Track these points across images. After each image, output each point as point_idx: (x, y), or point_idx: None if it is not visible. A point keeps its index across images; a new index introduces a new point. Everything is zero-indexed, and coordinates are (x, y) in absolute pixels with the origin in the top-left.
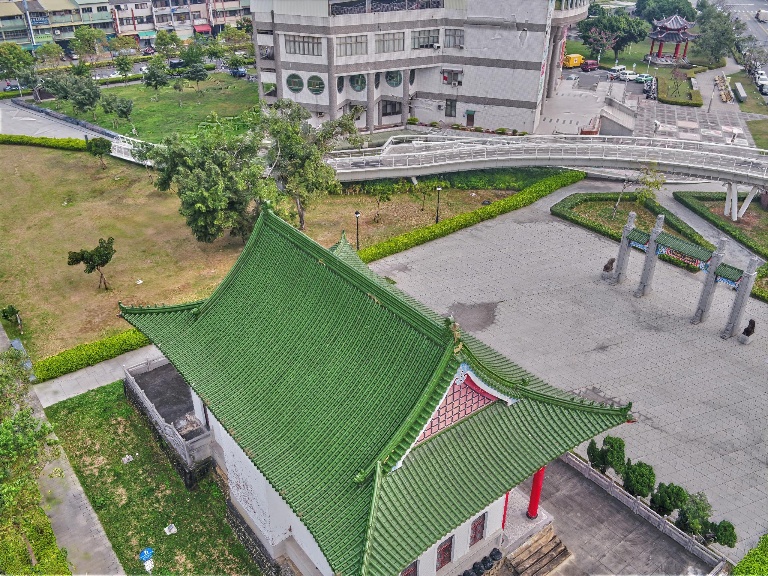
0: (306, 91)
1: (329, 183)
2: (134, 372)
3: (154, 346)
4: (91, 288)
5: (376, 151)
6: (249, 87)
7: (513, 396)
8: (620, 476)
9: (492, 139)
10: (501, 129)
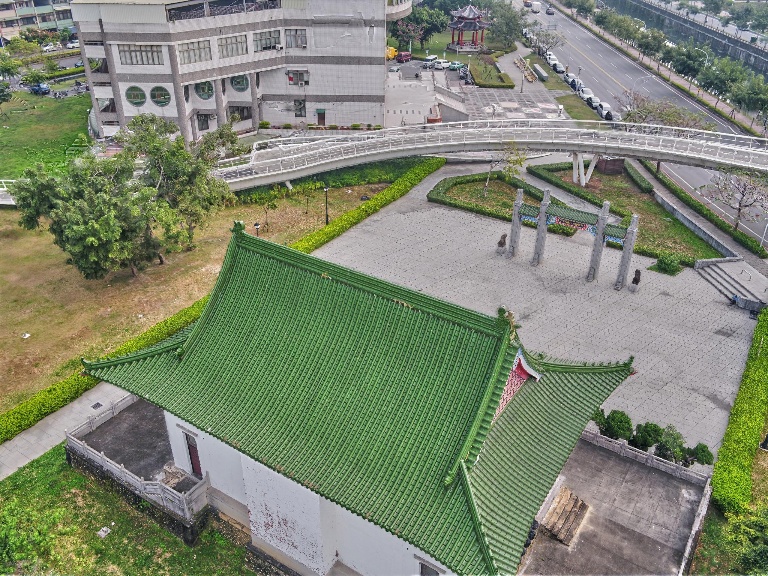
0: (150, 104)
1: (226, 197)
2: (77, 435)
3: (77, 403)
4: None
5: (245, 159)
6: (60, 105)
7: (540, 372)
8: (602, 426)
9: (354, 135)
10: (355, 125)
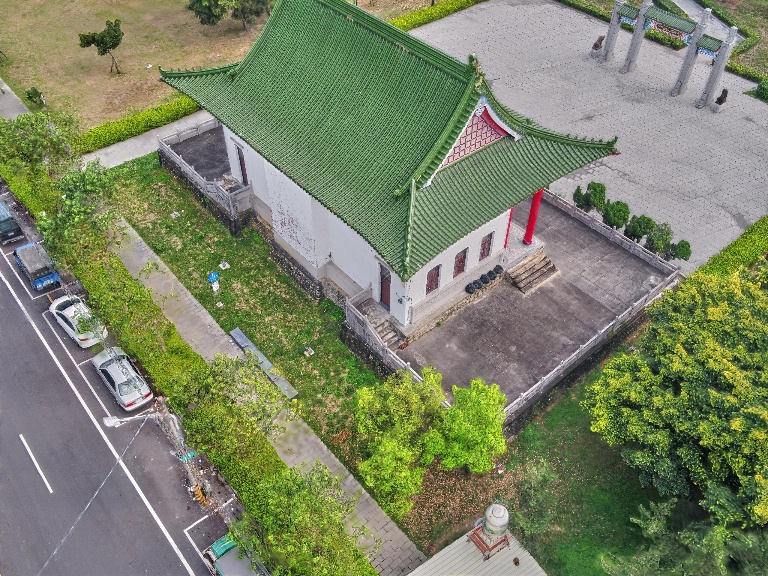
0: None
1: None
2: (167, 142)
3: (177, 123)
4: (103, 72)
5: None
6: None
7: (519, 132)
8: (600, 212)
9: None
10: None
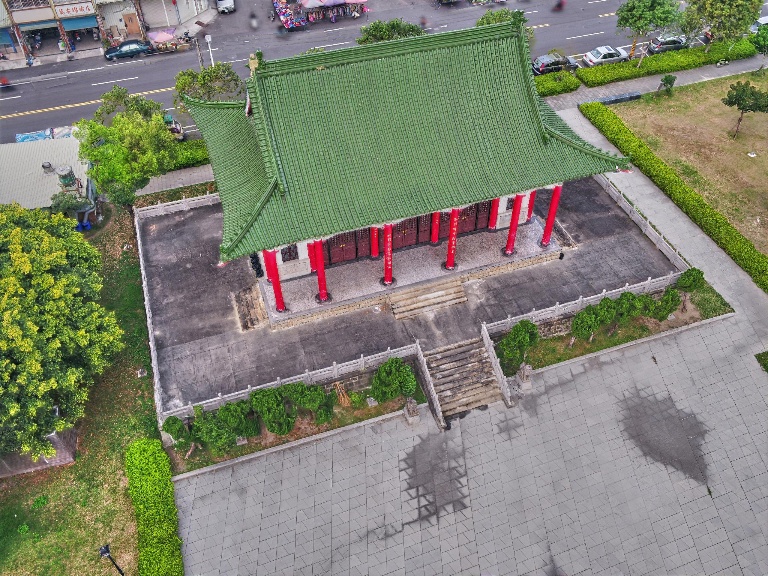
0: None
1: None
2: None
3: None
4: None
5: None
6: None
7: None
8: None
9: None
10: None
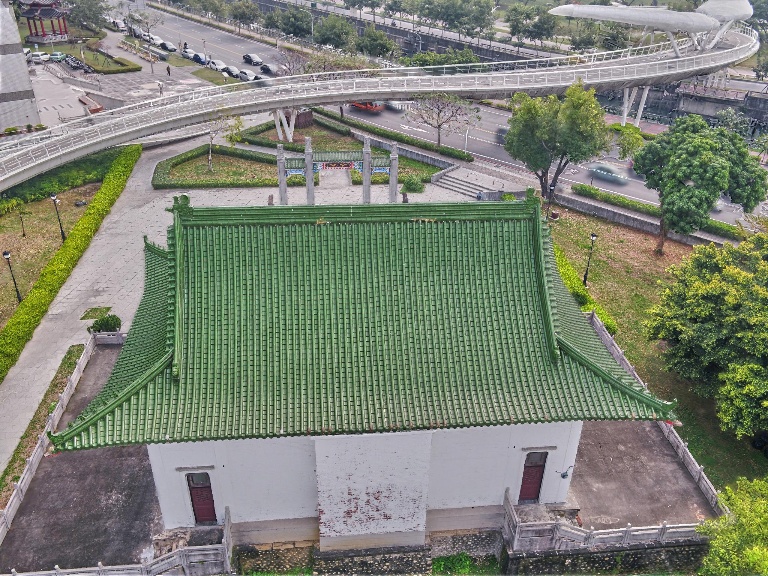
0: None
1: None
2: None
3: None
4: None
5: None
6: None
7: None
8: None
9: None
10: (10, 129)
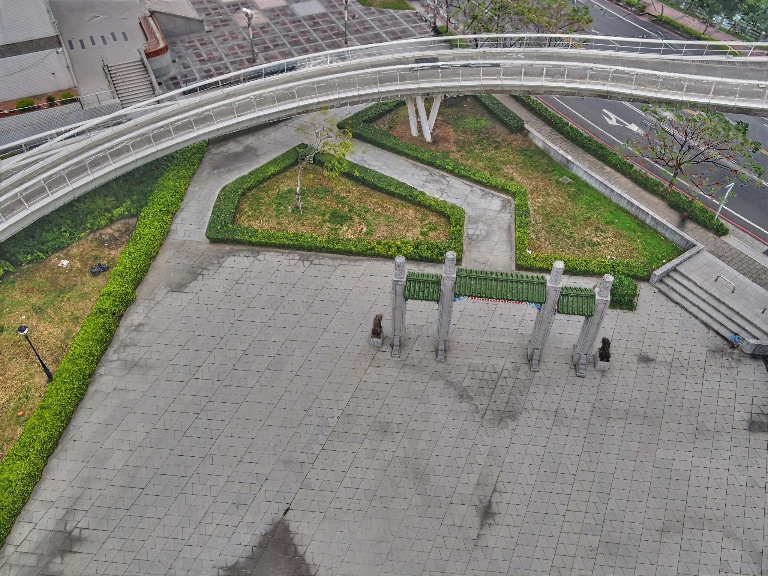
0: None
1: None
2: None
3: None
4: None
5: None
6: None
7: None
8: None
9: None
10: (23, 103)
